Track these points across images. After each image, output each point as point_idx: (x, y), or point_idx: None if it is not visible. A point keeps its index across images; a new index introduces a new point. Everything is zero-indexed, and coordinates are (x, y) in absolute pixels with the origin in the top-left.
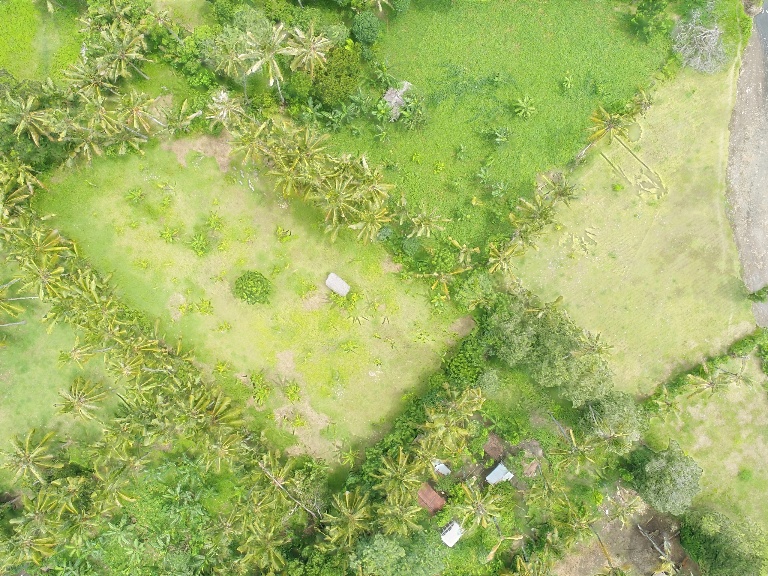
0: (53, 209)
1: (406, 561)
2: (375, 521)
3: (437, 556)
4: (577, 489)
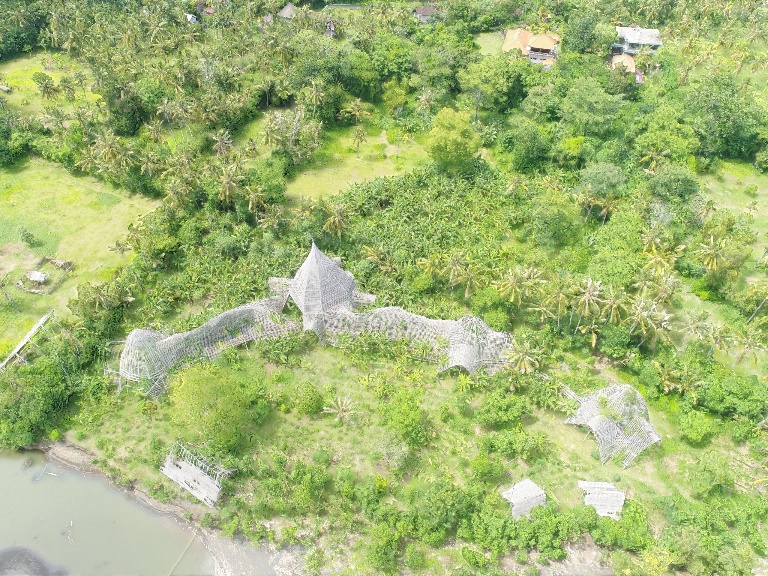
0: None
1: None
2: (2, 7)
3: None
4: None
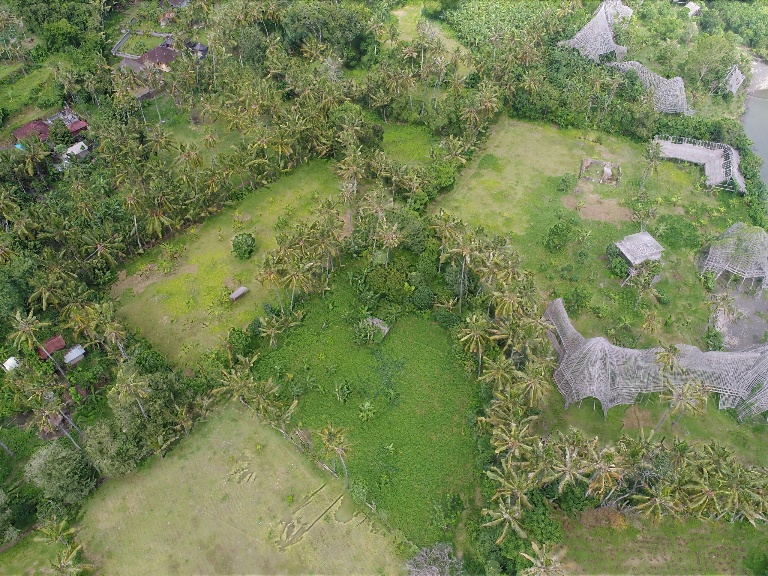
0: (313, 166)
1: (8, 281)
2: None
3: (2, 306)
4: (7, 469)
